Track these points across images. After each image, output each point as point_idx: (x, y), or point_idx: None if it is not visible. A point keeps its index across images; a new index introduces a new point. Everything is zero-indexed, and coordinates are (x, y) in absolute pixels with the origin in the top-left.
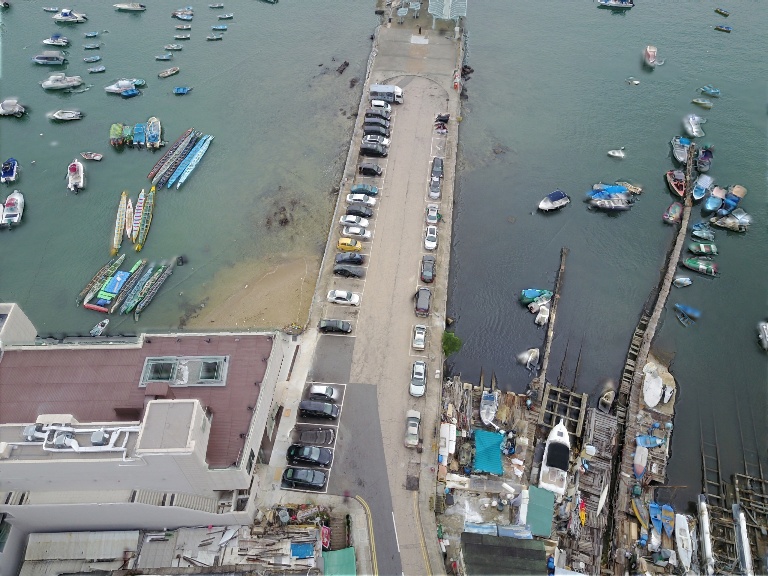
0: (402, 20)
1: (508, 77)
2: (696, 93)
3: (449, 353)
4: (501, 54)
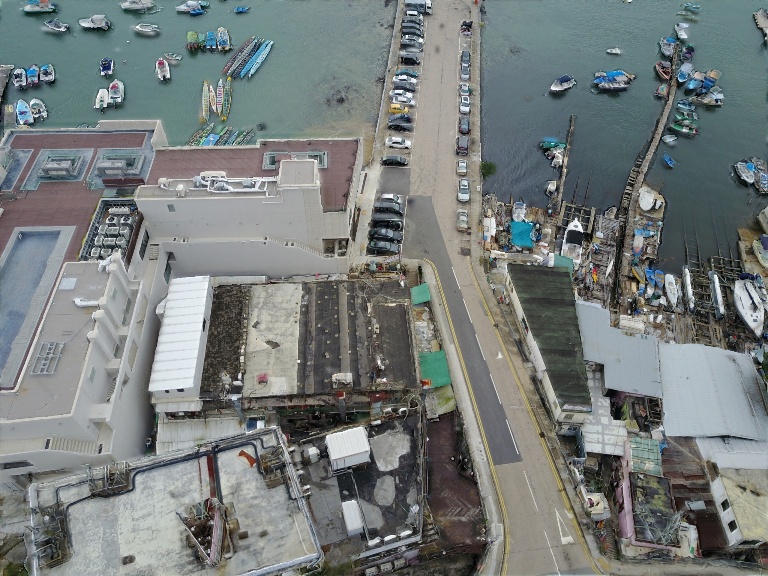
0: None
1: None
2: (680, 8)
3: (486, 176)
4: None
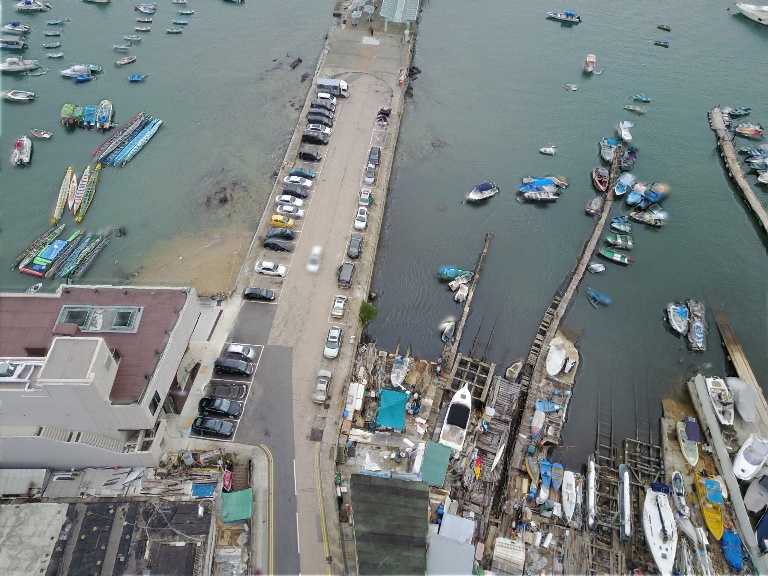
0: (356, 22)
1: (453, 79)
2: (628, 101)
3: (366, 321)
4: (449, 58)
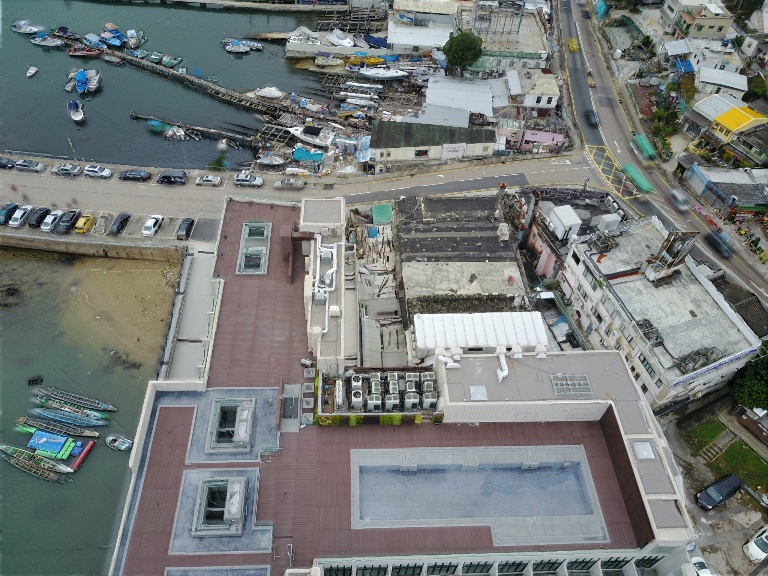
0: None
1: None
2: None
3: None
4: None
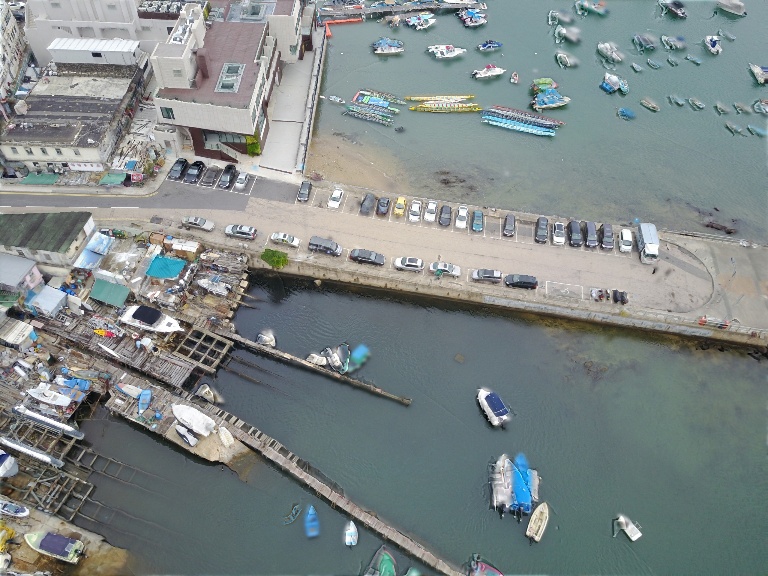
0: None
1: None
2: None
3: None
4: None
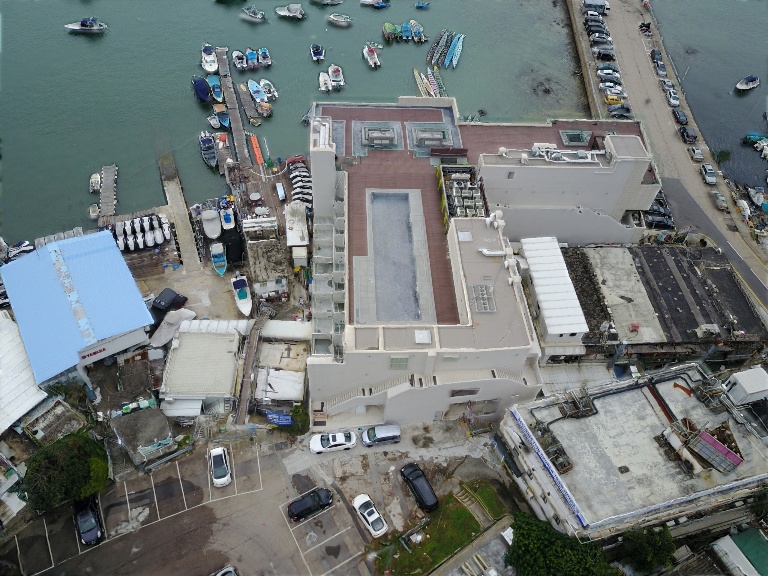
0: None
1: (676, 4)
2: None
3: (721, 163)
4: None
